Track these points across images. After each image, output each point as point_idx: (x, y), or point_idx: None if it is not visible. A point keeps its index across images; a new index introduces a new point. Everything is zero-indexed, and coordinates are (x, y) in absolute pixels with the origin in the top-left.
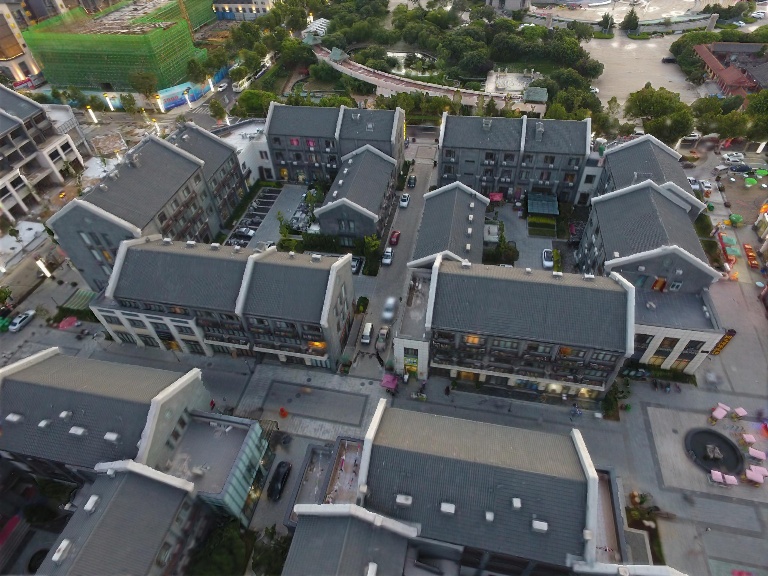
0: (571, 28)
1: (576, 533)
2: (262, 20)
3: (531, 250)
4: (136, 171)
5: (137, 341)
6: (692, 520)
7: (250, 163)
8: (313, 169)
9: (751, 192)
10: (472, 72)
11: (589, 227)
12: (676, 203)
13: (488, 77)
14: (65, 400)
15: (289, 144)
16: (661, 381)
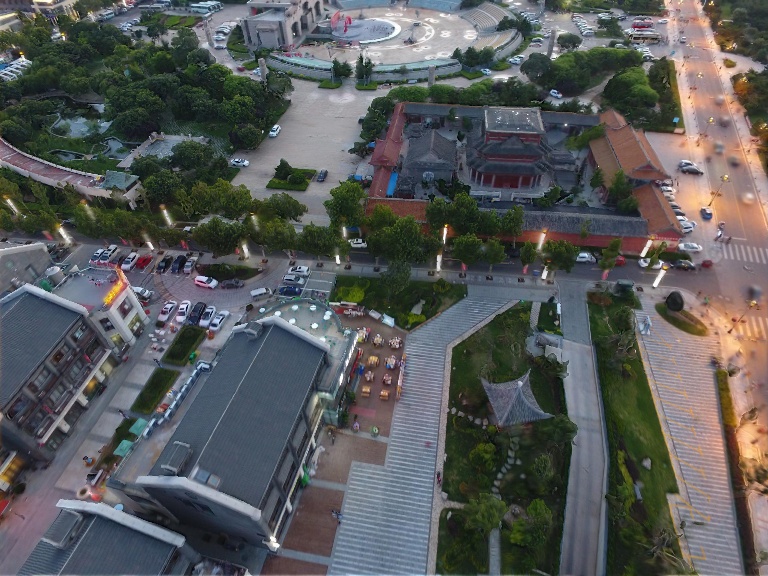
0: None
1: None
2: None
3: None
4: None
5: None
6: None
7: None
8: None
9: None
10: None
11: None
12: None
13: (145, 142)
14: None
15: None
16: None
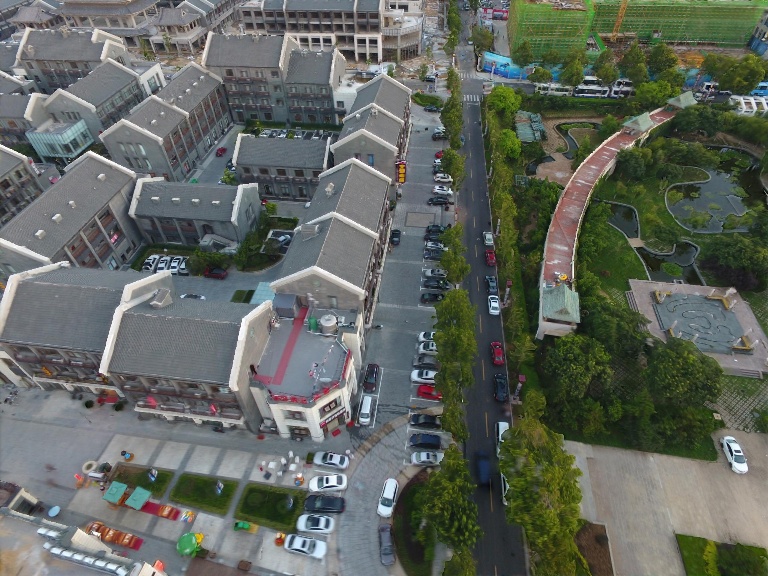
0: None
1: None
2: (709, 58)
3: (214, 291)
4: (252, 43)
5: None
6: None
7: None
8: None
9: None
10: None
11: None
12: None
13: (709, 287)
14: None
15: None
16: None
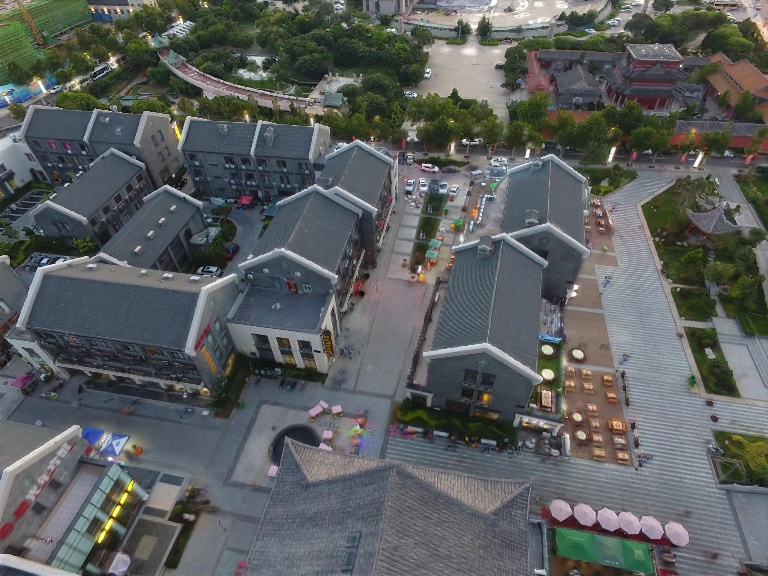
0: (413, 34)
1: None
2: (120, 22)
3: None
4: None
5: None
6: (234, 513)
7: (14, 165)
8: None
9: None
10: (305, 76)
11: None
12: (347, 207)
13: (321, 81)
14: None
15: (48, 147)
16: (291, 380)
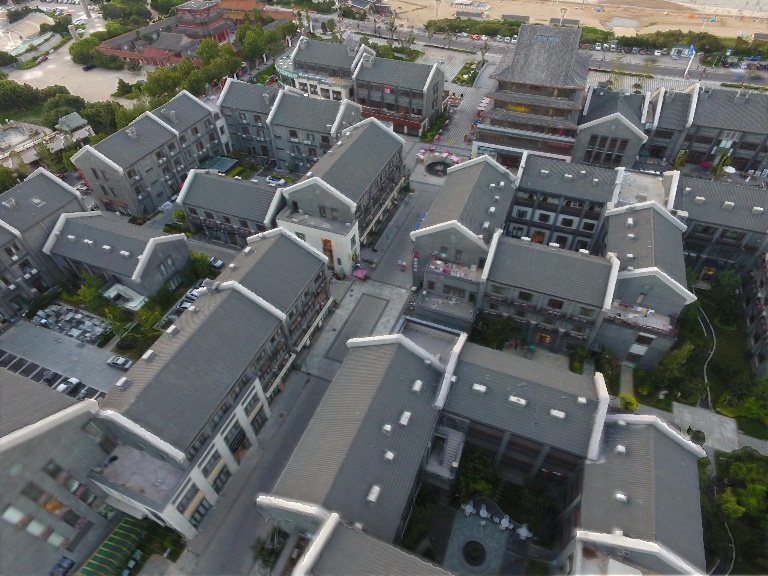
0: None
1: (504, 178)
2: None
3: None
4: None
5: (211, 499)
6: None
7: None
8: (9, 297)
9: None
10: None
11: (278, 141)
12: None
13: None
14: (370, 430)
15: None
16: None
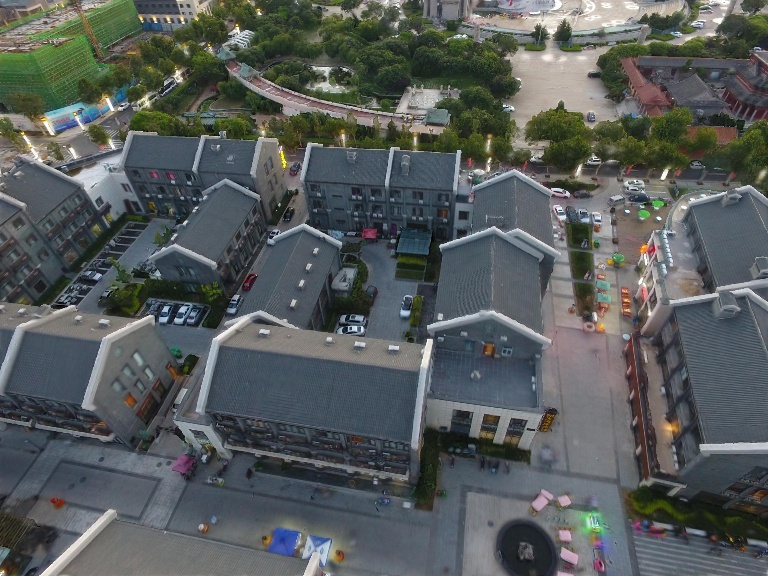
0: (496, 41)
1: None
2: (179, 33)
3: (393, 296)
4: None
5: None
6: None
7: (110, 197)
8: (180, 202)
9: (644, 226)
10: (387, 89)
11: None
12: (527, 251)
13: (404, 94)
14: None
15: (149, 177)
16: (491, 459)
